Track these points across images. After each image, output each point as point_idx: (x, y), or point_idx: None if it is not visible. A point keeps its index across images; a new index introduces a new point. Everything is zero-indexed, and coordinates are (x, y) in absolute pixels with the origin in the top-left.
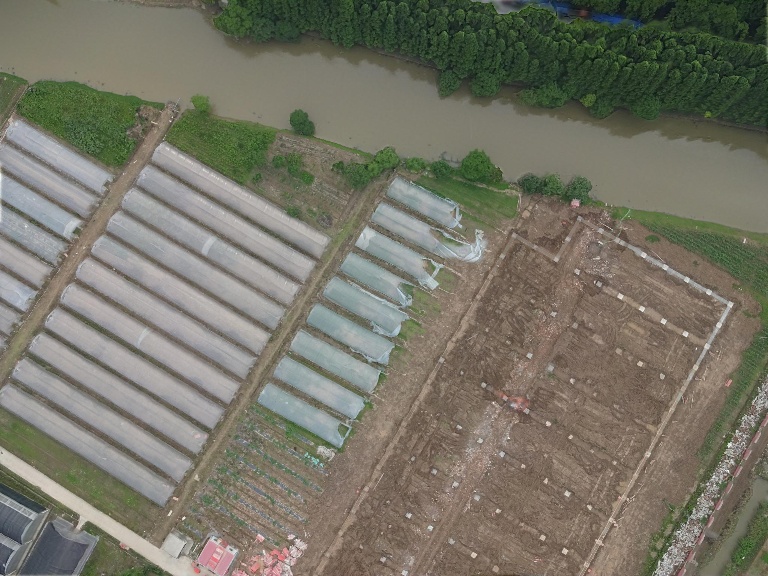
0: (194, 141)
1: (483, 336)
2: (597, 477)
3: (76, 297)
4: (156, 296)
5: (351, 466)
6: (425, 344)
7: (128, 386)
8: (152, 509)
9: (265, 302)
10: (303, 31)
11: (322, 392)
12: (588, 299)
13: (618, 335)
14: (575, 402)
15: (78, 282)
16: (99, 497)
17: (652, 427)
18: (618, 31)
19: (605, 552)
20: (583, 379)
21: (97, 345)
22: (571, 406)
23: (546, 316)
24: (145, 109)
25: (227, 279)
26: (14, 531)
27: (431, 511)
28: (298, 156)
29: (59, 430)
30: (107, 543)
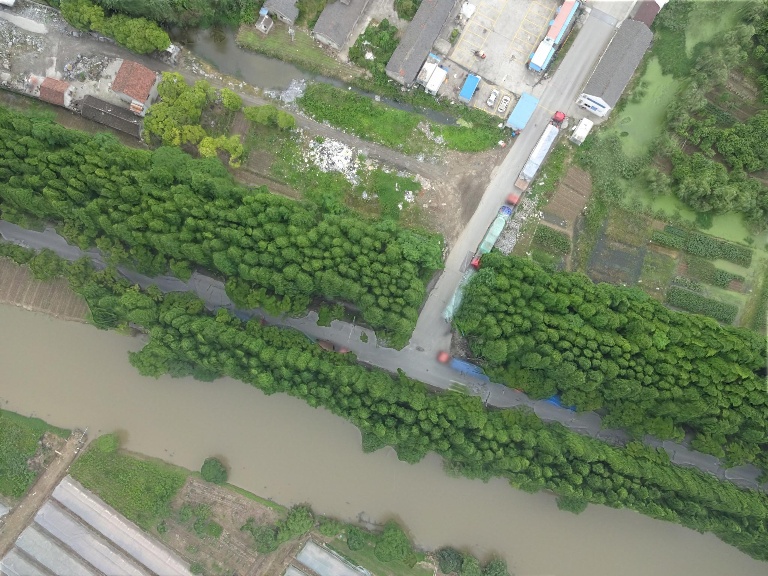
0: (99, 478)
1: None
2: None
3: None
4: None
5: None
6: None
7: None
8: None
9: None
10: (223, 375)
11: None
12: None
13: None
14: None
15: None
16: None
17: None
18: (545, 449)
19: None
20: None
21: None
22: None
23: None
24: (49, 438)
25: None
26: None
27: None
28: (207, 509)
29: None
30: None
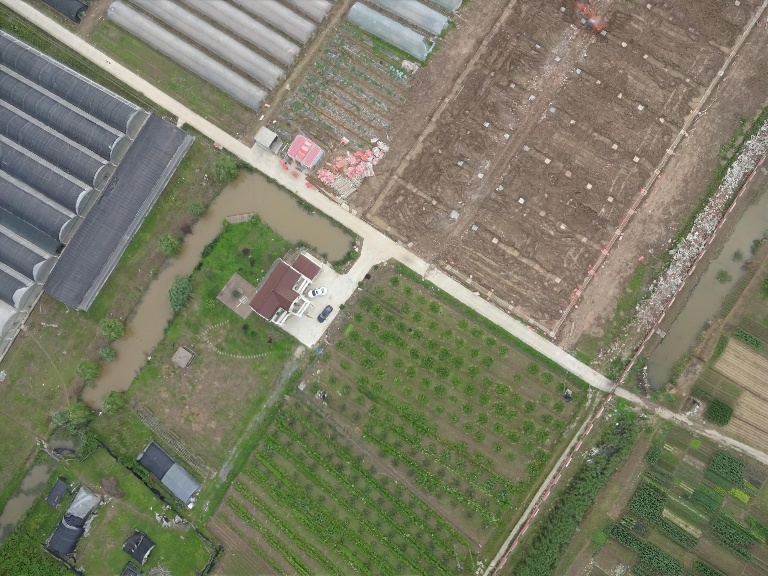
0: None
1: None
2: (670, 92)
3: None
4: None
5: (433, 79)
6: None
7: (228, 4)
8: (245, 114)
9: None
10: None
11: (408, 13)
12: None
13: None
14: (651, 24)
15: None
16: (197, 102)
17: (726, 49)
18: None
19: (676, 160)
20: (660, 3)
21: None
22: (647, 27)
23: None
24: None
25: None
26: (120, 119)
27: (508, 120)
28: None
29: (162, 44)
30: (202, 143)
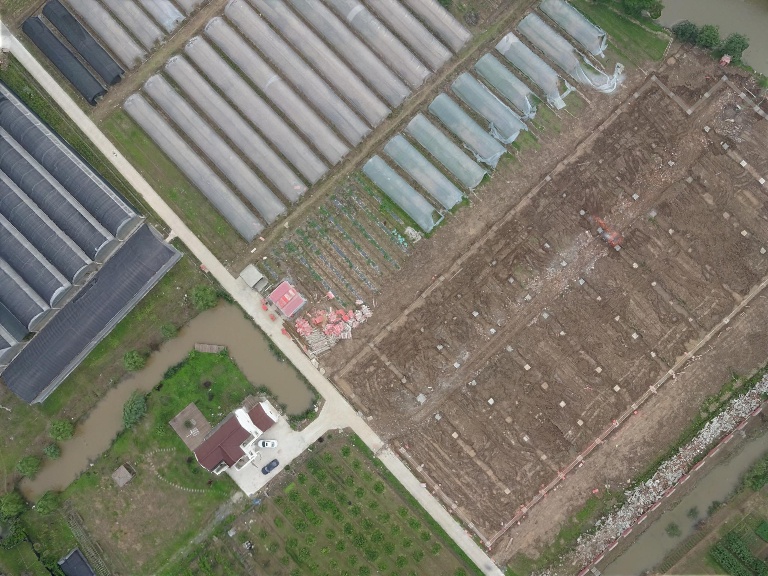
0: None
1: (595, 165)
2: (669, 327)
3: (219, 31)
4: (293, 49)
5: (433, 253)
6: (536, 159)
7: (246, 124)
8: (238, 242)
9: (394, 79)
10: None
11: (425, 178)
12: (710, 157)
13: (730, 199)
14: (668, 251)
15: (224, 18)
16: (193, 218)
17: (738, 296)
18: None
19: (656, 400)
20: (683, 232)
21: (227, 80)
22: (663, 254)
23: (663, 163)
24: None
25: (364, 50)
26: (112, 222)
27: (498, 315)
28: None
29: (172, 149)
30: (189, 262)
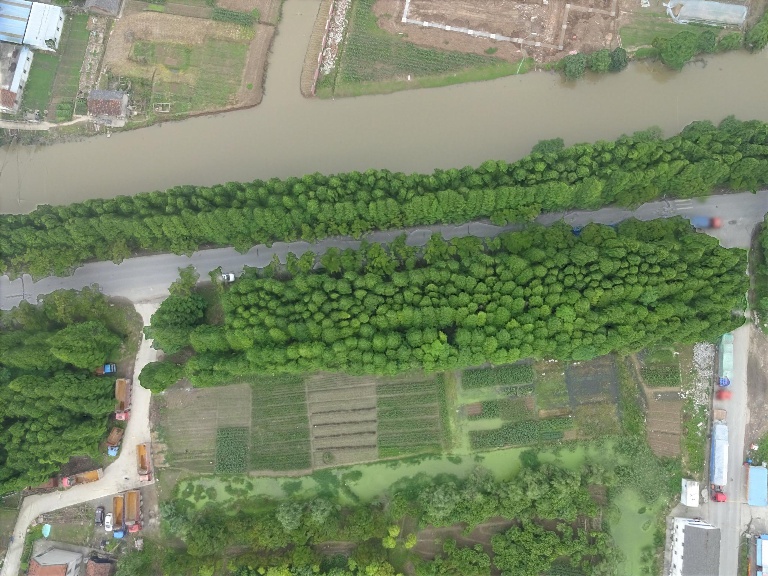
0: None
1: None
2: None
3: None
4: None
5: None
6: None
7: None
8: None
9: None
10: None
11: None
12: None
13: None
14: None
15: None
16: None
17: None
18: None
19: None
20: None
21: None
22: None
23: None
24: None
25: None
26: None
27: None
28: None
29: None
30: None
